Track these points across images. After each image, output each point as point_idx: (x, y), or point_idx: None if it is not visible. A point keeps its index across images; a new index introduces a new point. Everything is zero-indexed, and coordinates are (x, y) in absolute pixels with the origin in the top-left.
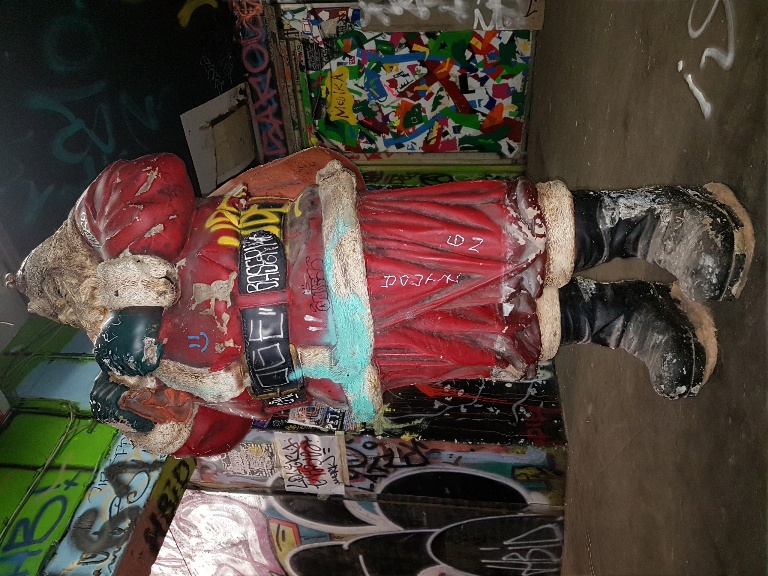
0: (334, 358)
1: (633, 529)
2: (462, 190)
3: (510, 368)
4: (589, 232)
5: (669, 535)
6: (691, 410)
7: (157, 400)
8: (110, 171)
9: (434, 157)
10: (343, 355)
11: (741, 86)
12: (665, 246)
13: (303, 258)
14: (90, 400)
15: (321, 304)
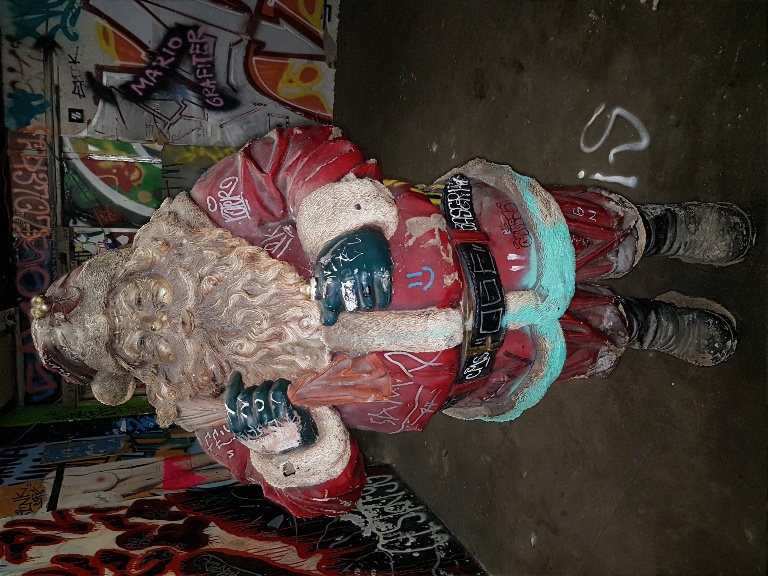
0: (541, 294)
1: (668, 574)
2: (554, 188)
3: (613, 346)
4: (643, 220)
5: (732, 524)
6: (713, 390)
7: (356, 371)
8: (278, 130)
9: None
10: (553, 286)
11: (668, 149)
12: (689, 229)
13: (493, 205)
14: (230, 410)
15: (524, 240)
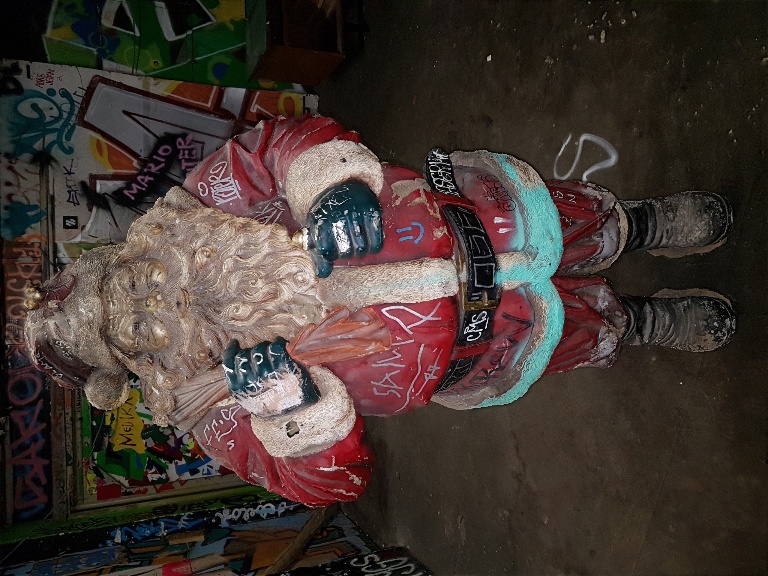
0: (531, 253)
1: None
2: None
3: (613, 327)
4: (622, 209)
5: None
6: (722, 379)
7: None
8: None
9: (233, 478)
10: (542, 244)
11: (636, 159)
12: (668, 217)
13: (474, 178)
14: (228, 369)
15: (507, 204)
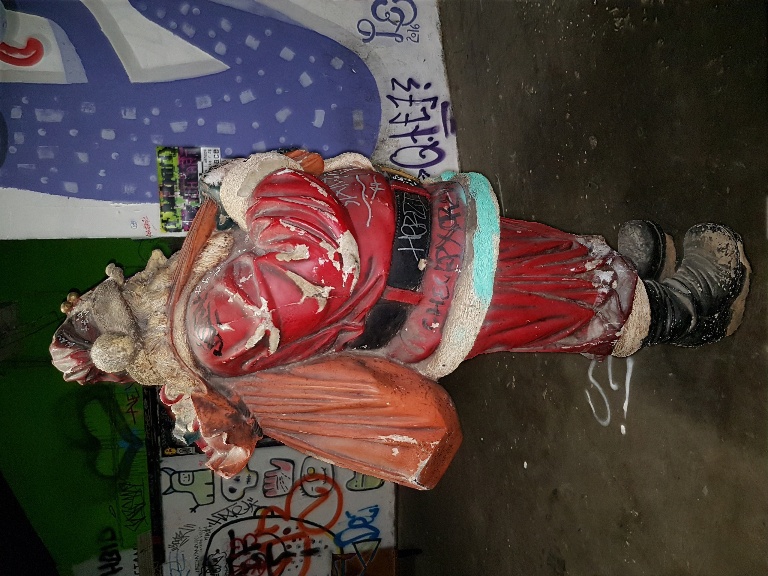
0: None
1: None
2: None
3: None
4: None
5: None
6: None
7: None
8: None
9: None
10: None
11: None
12: None
13: None
14: None
15: None
